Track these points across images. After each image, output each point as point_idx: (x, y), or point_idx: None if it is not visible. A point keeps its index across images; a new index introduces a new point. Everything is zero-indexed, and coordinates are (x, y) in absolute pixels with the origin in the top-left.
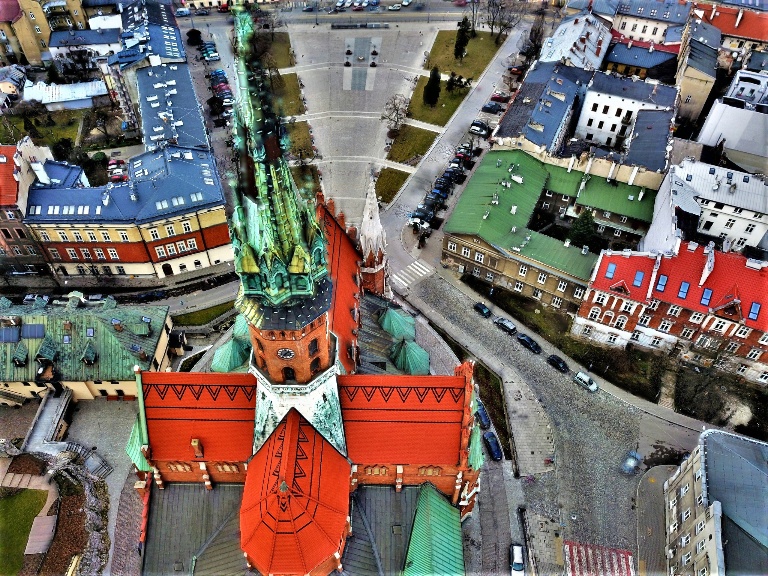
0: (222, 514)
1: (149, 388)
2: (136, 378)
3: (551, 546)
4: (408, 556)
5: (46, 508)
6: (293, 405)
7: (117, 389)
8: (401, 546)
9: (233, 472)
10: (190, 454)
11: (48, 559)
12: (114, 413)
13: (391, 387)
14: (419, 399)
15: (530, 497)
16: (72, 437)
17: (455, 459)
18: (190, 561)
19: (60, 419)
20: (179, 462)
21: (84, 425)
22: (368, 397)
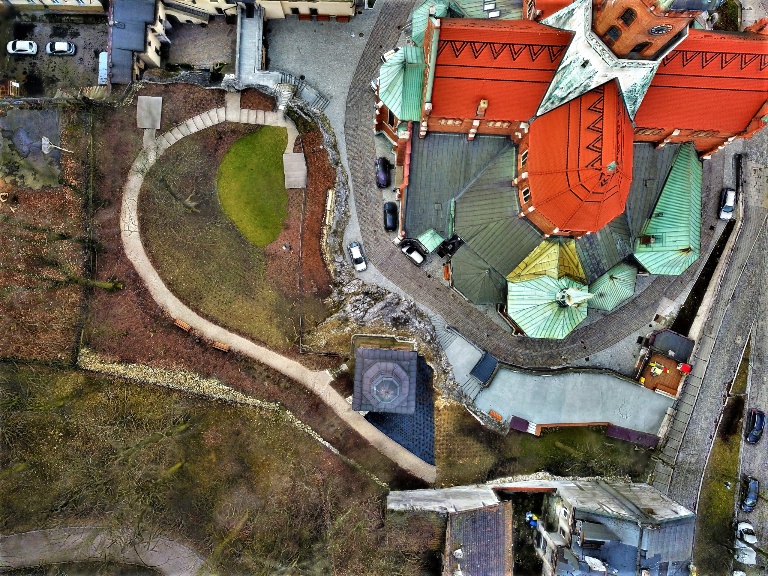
0: (480, 163)
1: (445, 45)
2: (434, 34)
3: (760, 191)
4: (657, 207)
5: (290, 145)
6: (618, 75)
7: (312, 8)
8: (651, 198)
9: (502, 127)
10: (471, 112)
11: (309, 193)
12: (311, 36)
13: (717, 52)
14: (741, 66)
15: (748, 143)
16: (275, 64)
17: (743, 126)
18: (449, 202)
19: (262, 44)
20: (454, 118)
21: (283, 50)
22: (685, 62)
